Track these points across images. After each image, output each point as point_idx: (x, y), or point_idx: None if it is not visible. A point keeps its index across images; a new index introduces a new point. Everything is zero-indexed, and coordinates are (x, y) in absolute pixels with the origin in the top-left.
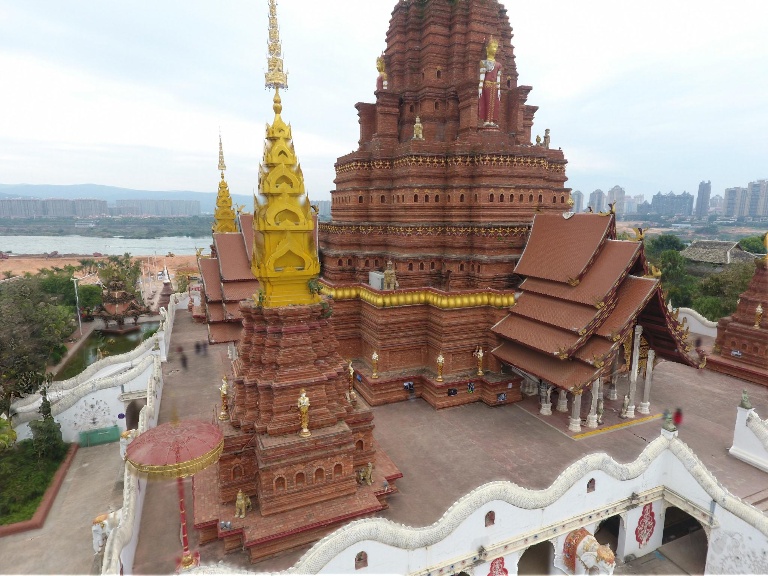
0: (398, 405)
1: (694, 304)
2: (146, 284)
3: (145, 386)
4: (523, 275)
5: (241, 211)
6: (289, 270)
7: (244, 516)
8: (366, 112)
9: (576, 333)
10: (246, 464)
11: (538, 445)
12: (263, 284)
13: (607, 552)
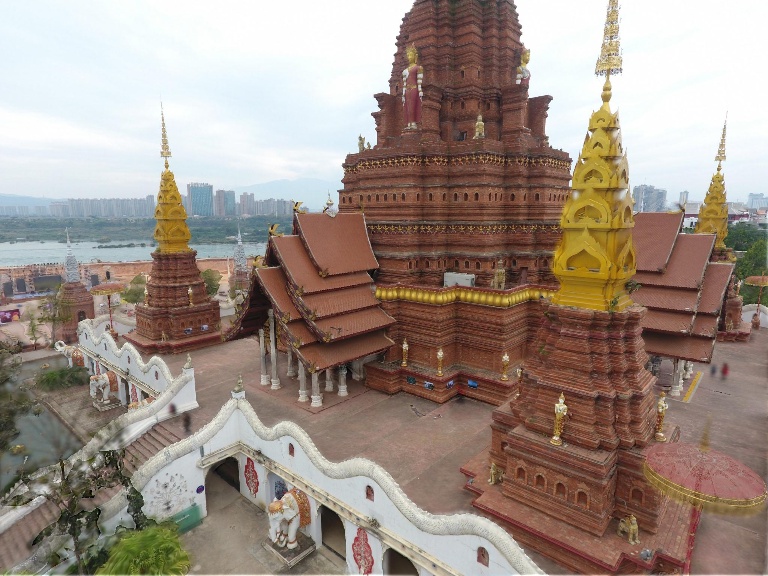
0: None
1: None
2: None
3: (227, 442)
4: None
5: None
6: (628, 270)
7: (639, 540)
8: (388, 104)
9: (691, 312)
10: (611, 486)
11: (675, 412)
12: (603, 287)
13: None
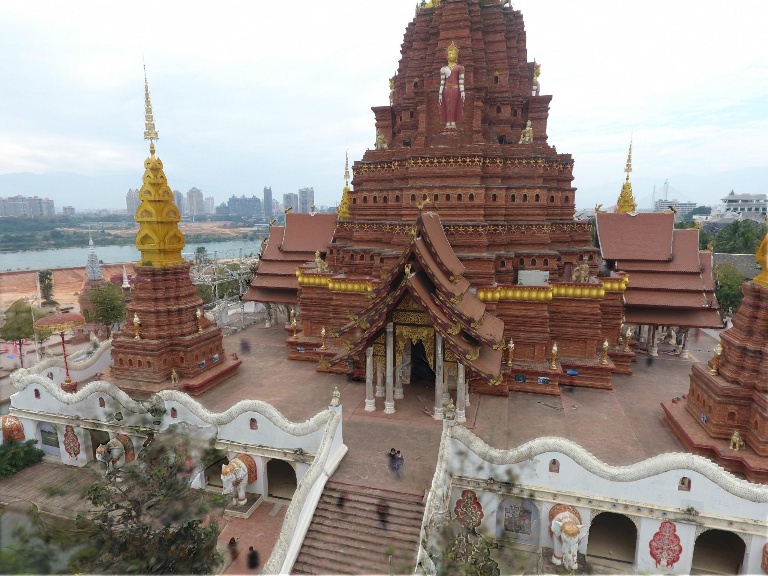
0: (614, 382)
1: None
2: None
3: None
4: (615, 259)
5: None
6: None
7: None
8: (426, 100)
9: (703, 291)
10: None
11: None
12: None
13: None
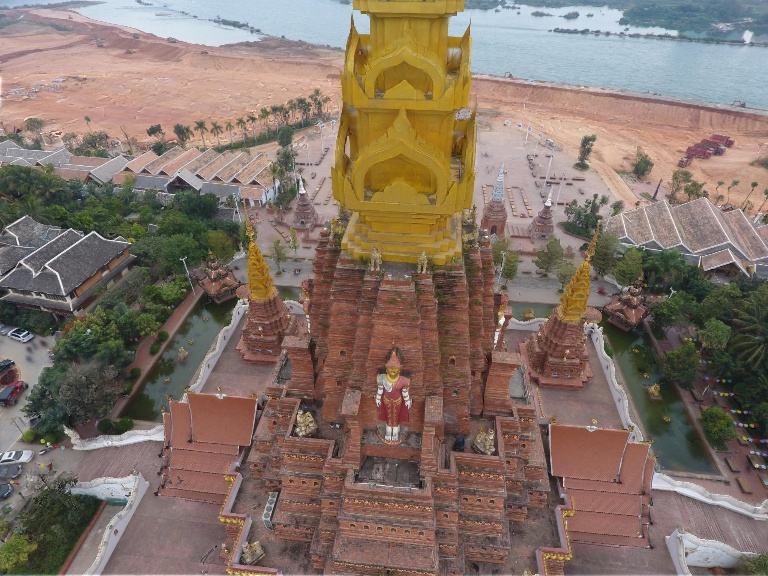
0: None
1: (766, 556)
2: (329, 127)
3: None
4: None
5: (187, 391)
6: None
7: None
8: None
9: None
10: None
11: None
12: None
13: None
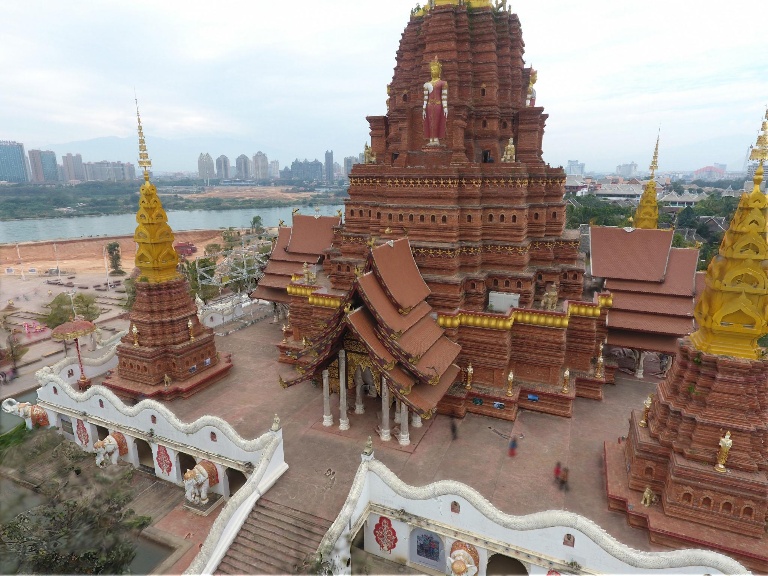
0: (578, 409)
1: None
2: None
3: (362, 506)
4: (604, 277)
5: None
6: None
7: None
8: (409, 117)
9: (692, 317)
10: None
11: None
12: (752, 339)
13: None
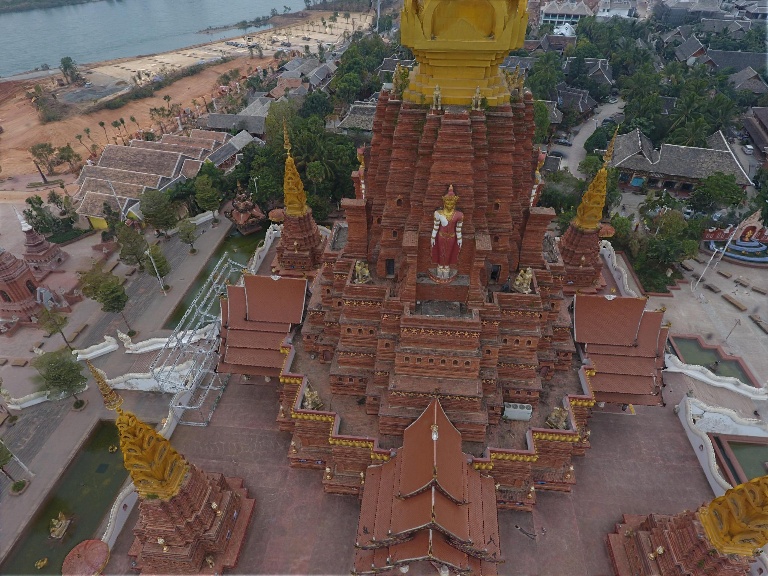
0: None
1: None
2: None
3: None
4: None
5: None
6: None
7: None
8: None
9: None
10: None
11: (639, 434)
12: None
13: (717, 466)
